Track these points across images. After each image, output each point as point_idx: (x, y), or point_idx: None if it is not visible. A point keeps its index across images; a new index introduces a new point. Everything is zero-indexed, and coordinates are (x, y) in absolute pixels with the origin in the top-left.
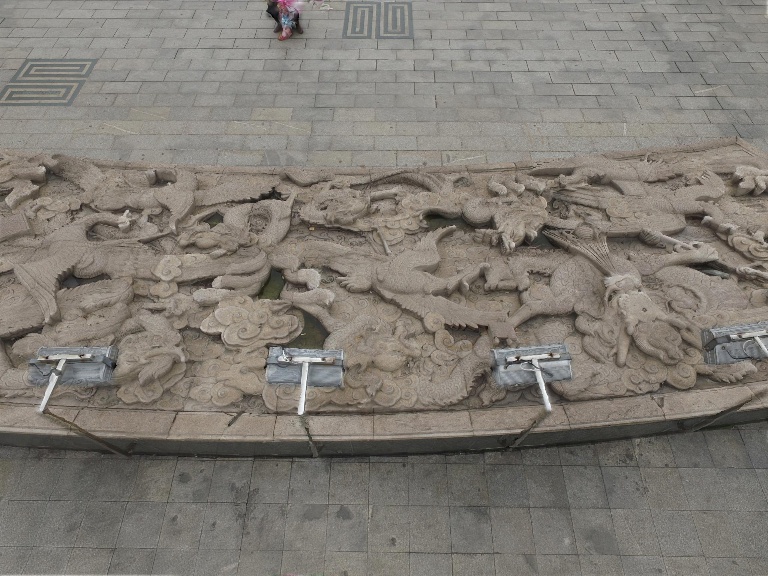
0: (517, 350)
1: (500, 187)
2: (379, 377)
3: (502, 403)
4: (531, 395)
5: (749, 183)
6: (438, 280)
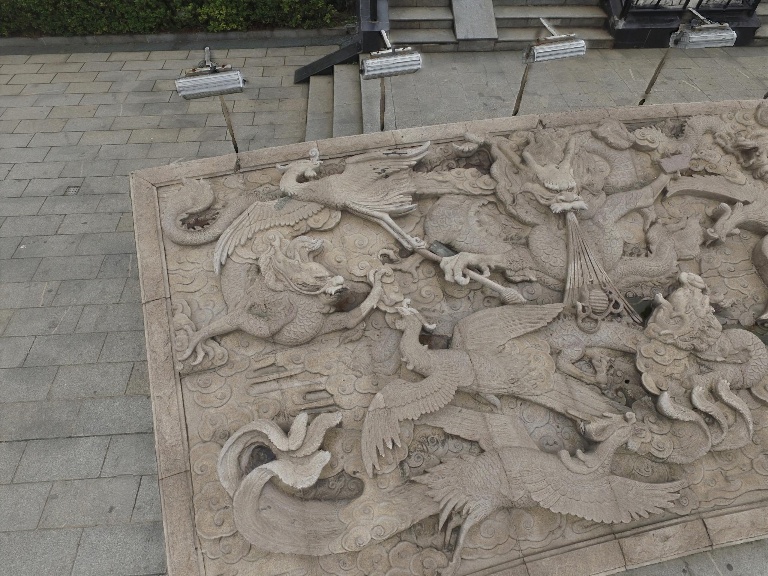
0: (720, 33)
1: (733, 398)
2: (761, 120)
3: (655, 123)
4: (634, 129)
5: (324, 422)
6: (755, 212)
